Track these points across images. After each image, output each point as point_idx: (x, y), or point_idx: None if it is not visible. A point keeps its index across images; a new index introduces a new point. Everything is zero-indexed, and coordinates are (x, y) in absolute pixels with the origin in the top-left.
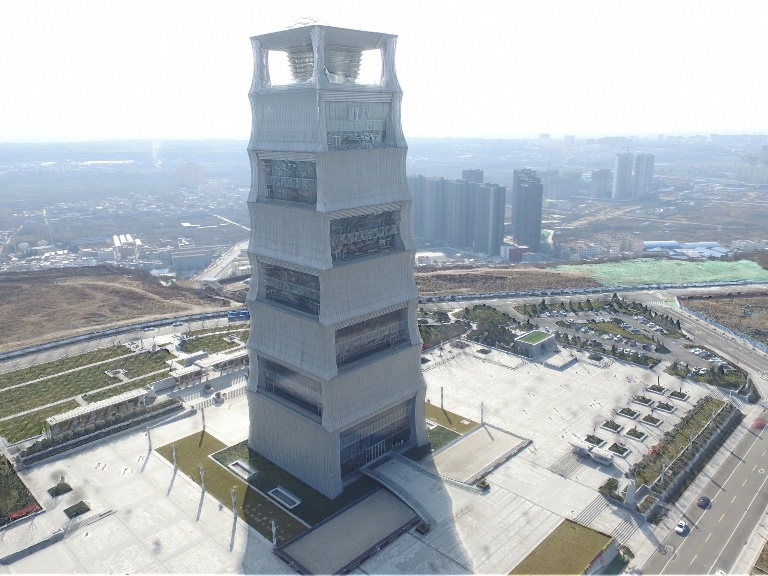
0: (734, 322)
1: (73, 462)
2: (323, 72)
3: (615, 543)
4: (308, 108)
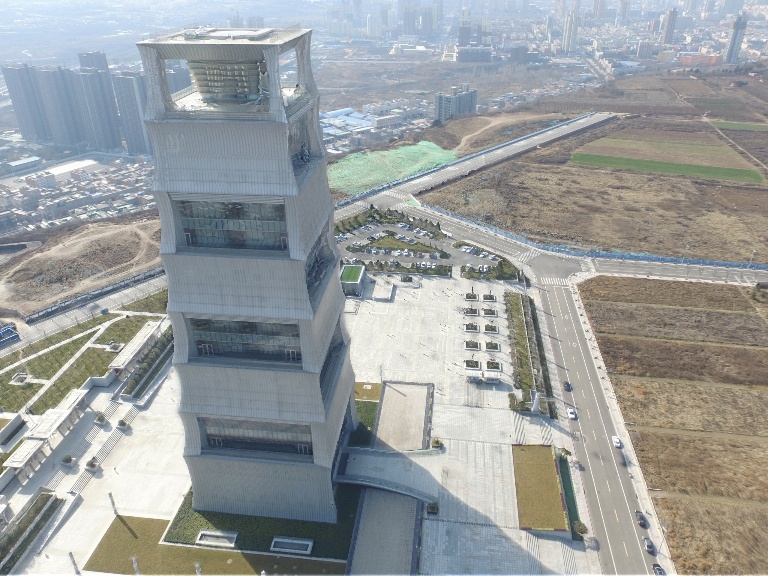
0: (466, 211)
1: None
2: None
3: (557, 449)
4: (269, 144)
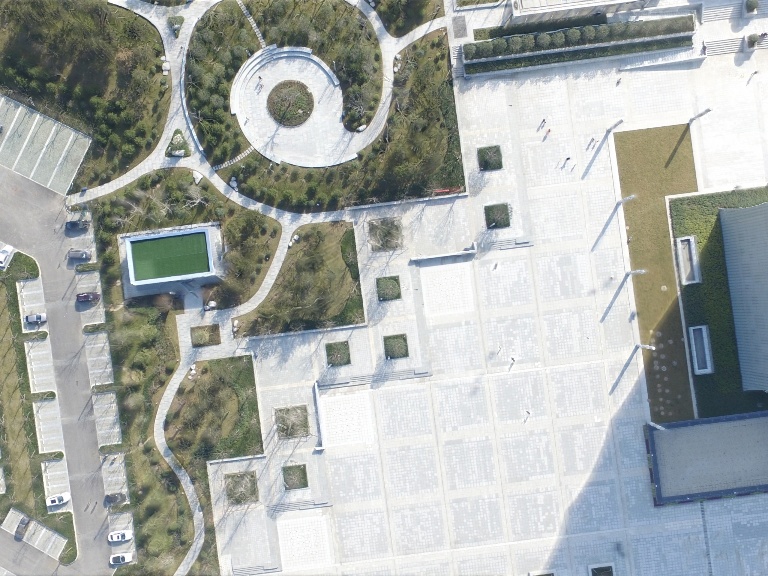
0: None
1: (517, 95)
2: None
3: None
4: None
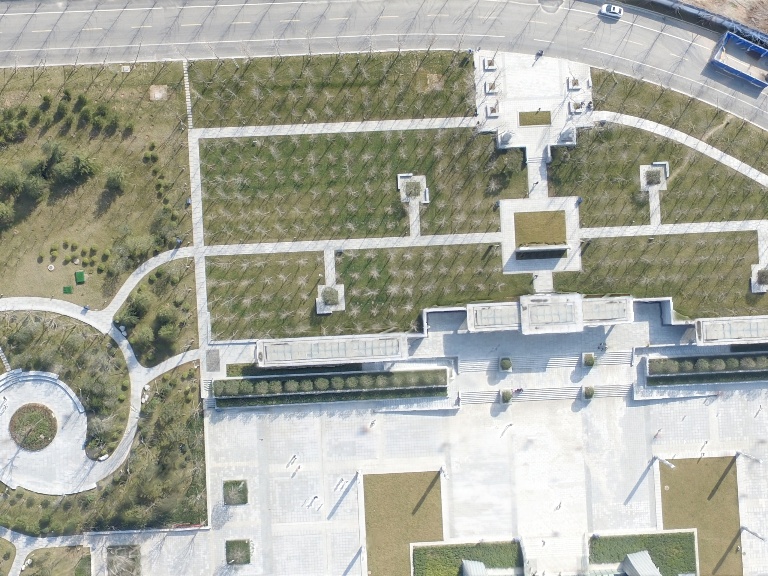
0: None
1: (269, 429)
2: None
3: None
4: None
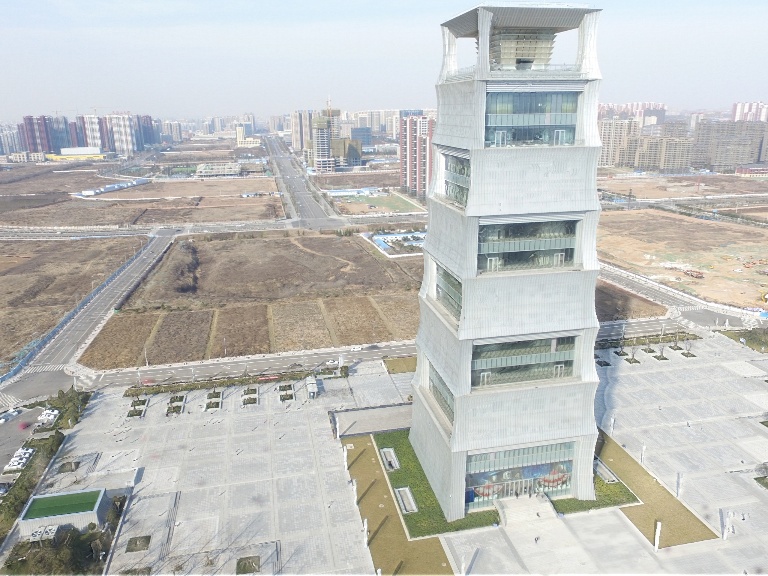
0: None
1: None
2: None
3: None
4: None
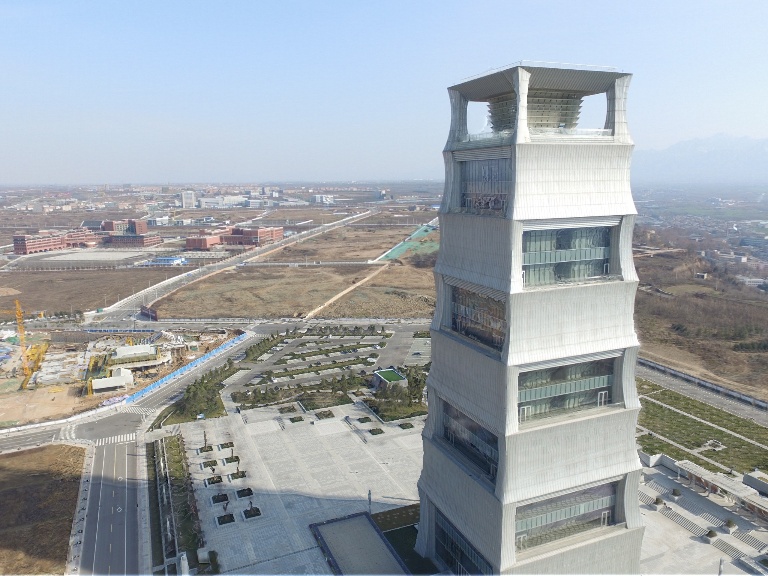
0: None
1: None
2: (456, 133)
3: None
4: None
